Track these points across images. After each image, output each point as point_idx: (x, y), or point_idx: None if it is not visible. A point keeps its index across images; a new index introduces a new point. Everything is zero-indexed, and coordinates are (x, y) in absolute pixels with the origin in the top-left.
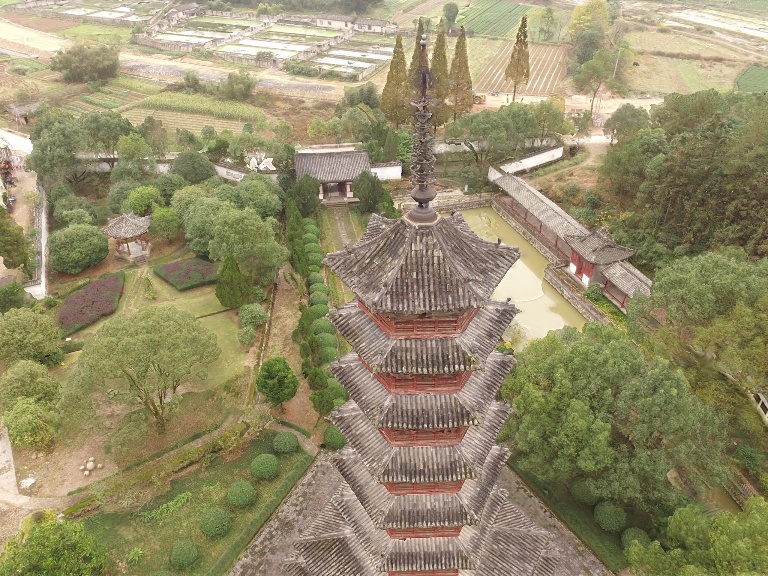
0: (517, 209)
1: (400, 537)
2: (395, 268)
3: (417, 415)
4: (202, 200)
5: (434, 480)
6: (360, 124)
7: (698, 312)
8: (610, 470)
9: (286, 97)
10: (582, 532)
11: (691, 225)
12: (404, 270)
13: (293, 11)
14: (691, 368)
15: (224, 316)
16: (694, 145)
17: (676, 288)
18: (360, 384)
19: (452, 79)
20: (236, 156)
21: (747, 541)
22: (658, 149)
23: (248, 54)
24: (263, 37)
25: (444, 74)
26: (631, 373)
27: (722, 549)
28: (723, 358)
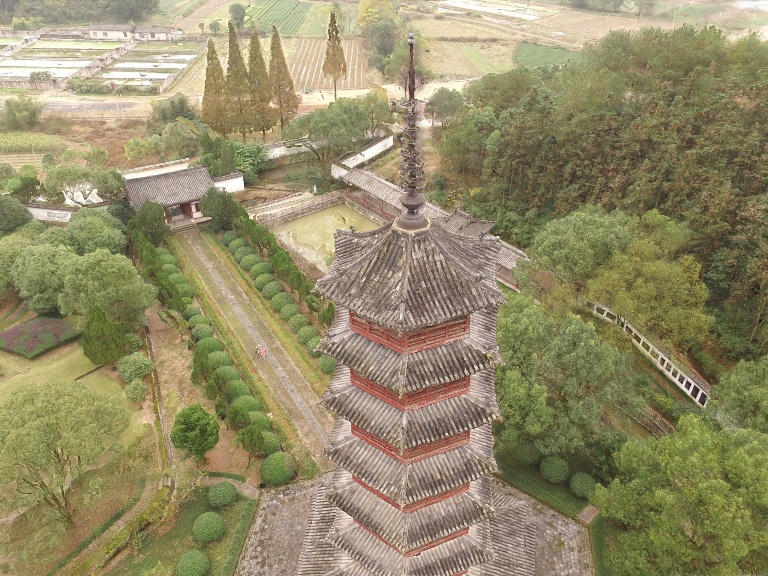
0: (370, 202)
1: (415, 553)
2: (405, 281)
3: (435, 426)
4: (31, 250)
5: (455, 486)
6: (184, 139)
7: (583, 267)
8: (554, 427)
9: (82, 120)
10: (536, 492)
11: (535, 191)
12: (412, 281)
13: (55, 24)
14: (588, 318)
15: (98, 375)
16: (522, 118)
17: (557, 249)
18: (362, 410)
19: (273, 81)
20: (50, 193)
21: (697, 456)
22: (491, 126)
23: (17, 76)
24: (28, 56)
25: (264, 77)
26: (547, 334)
27: (679, 469)
28: (617, 303)
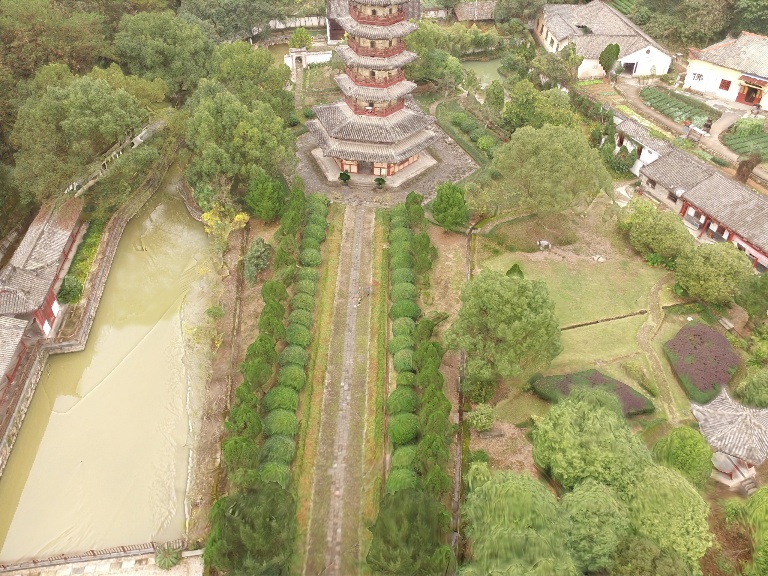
0: None
1: None
2: None
3: None
4: (622, 445)
5: None
6: None
7: None
8: None
9: None
10: None
11: None
12: None
13: None
14: None
15: None
16: None
17: None
18: None
19: None
20: None
21: None
22: None
23: None
24: None
25: None
26: None
27: None
28: None
